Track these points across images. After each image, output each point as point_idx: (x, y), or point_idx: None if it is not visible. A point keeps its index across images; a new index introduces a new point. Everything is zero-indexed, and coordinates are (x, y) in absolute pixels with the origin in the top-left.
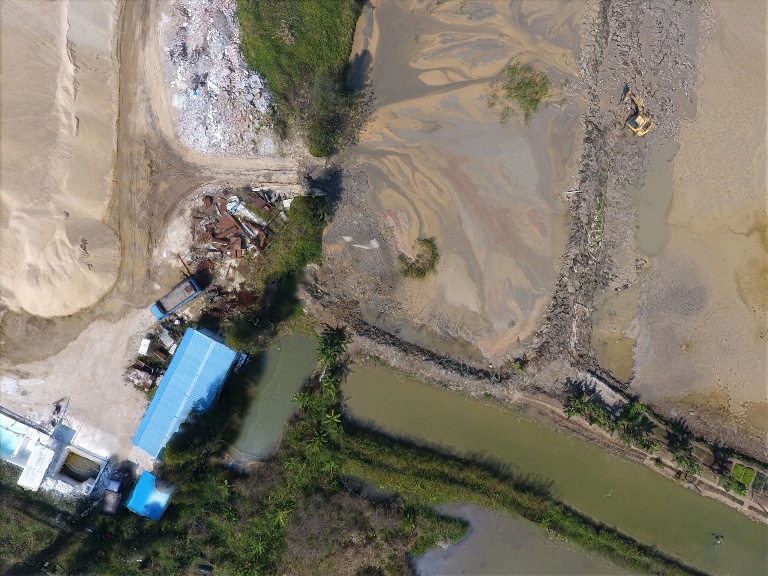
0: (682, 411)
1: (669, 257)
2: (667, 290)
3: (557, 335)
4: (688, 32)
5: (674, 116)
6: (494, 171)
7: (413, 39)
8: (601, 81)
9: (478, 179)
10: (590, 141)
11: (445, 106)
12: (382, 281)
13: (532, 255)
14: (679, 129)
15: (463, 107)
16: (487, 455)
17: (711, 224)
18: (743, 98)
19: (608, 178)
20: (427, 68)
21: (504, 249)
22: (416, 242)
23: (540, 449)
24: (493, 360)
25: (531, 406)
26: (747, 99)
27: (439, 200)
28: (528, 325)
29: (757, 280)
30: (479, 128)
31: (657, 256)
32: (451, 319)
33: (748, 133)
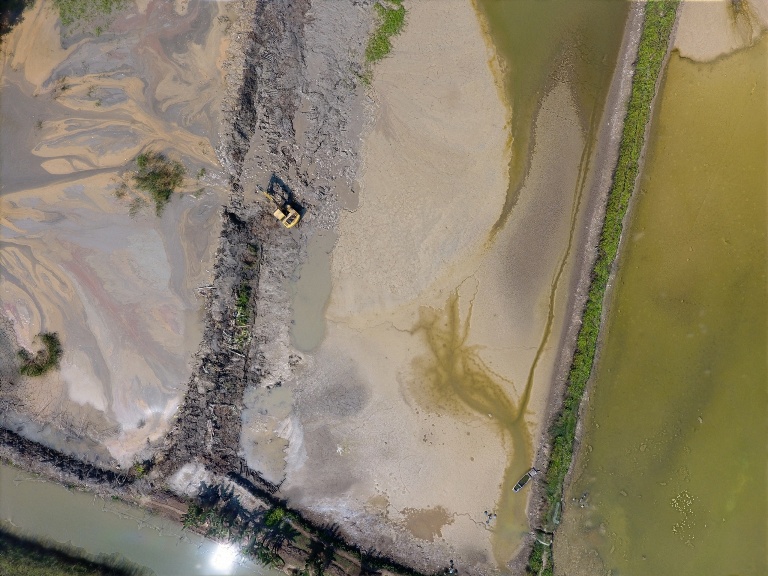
0: (335, 517)
1: (326, 354)
2: (322, 389)
3: (185, 438)
4: (351, 117)
5: (334, 206)
6: (123, 264)
7: (36, 126)
8: (246, 170)
9: (104, 273)
10: (225, 235)
11: (70, 196)
12: (2, 377)
13: (163, 353)
14: (339, 220)
15: (89, 197)
16: (119, 559)
17: (372, 320)
18: (409, 188)
19: (261, 270)
20: (51, 156)
21: (132, 346)
22: (34, 338)
23: (181, 553)
24: (121, 461)
25: (160, 511)
26: (414, 189)
27: (62, 294)
28: (159, 426)
29: (421, 380)
30: (107, 219)
31: (313, 353)
32: (75, 418)
33: (414, 225)
